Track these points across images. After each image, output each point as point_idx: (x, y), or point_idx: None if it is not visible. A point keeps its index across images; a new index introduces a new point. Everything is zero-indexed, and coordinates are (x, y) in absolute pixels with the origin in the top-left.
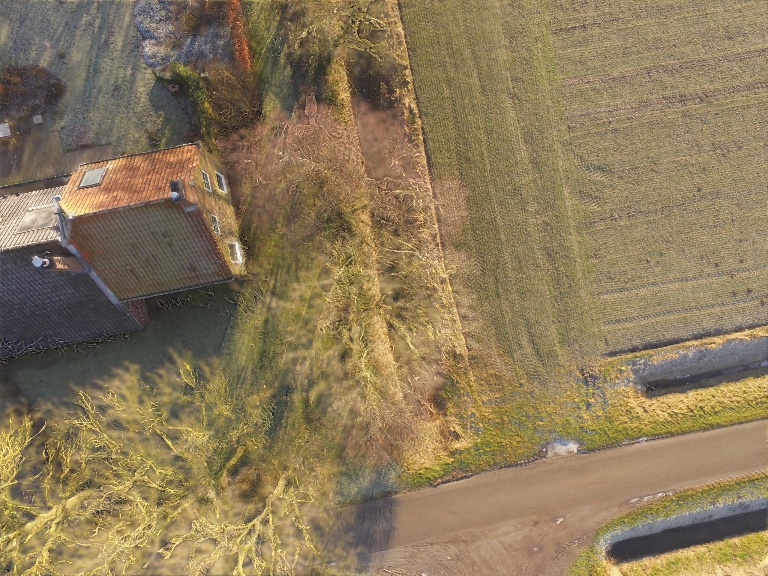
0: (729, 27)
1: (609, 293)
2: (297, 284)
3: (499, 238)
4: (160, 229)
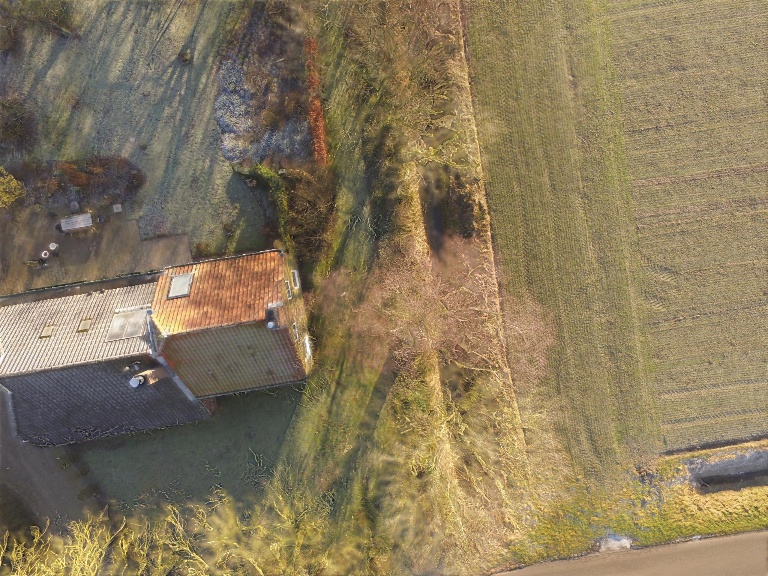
0: None
1: (670, 393)
2: (362, 374)
3: (563, 336)
4: (246, 343)
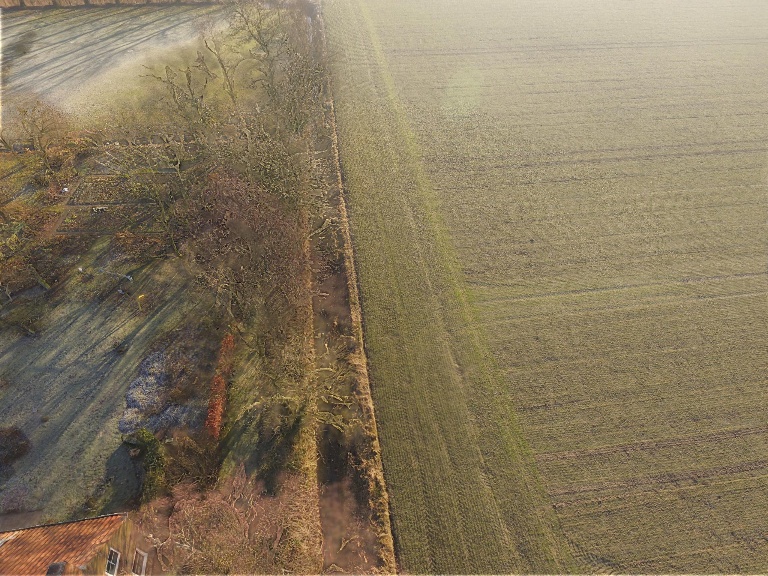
0: (690, 410)
1: None
2: None
3: None
4: None
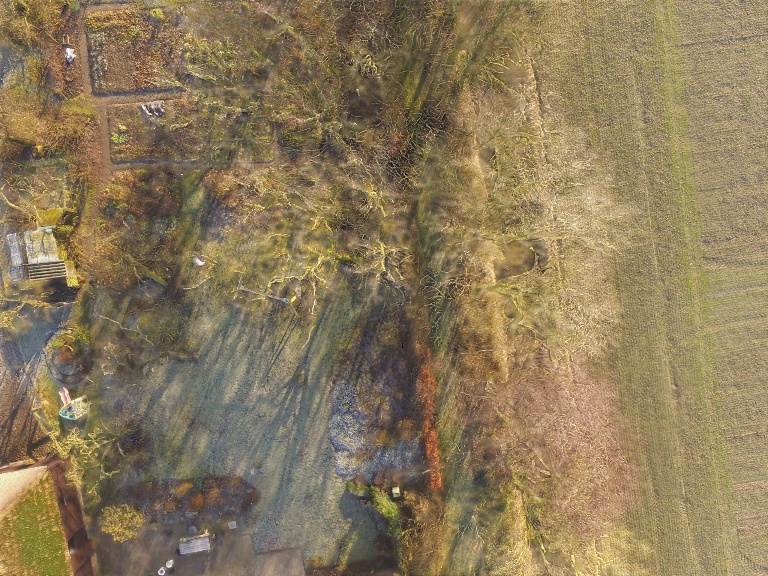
0: None
1: None
2: None
3: None
4: None
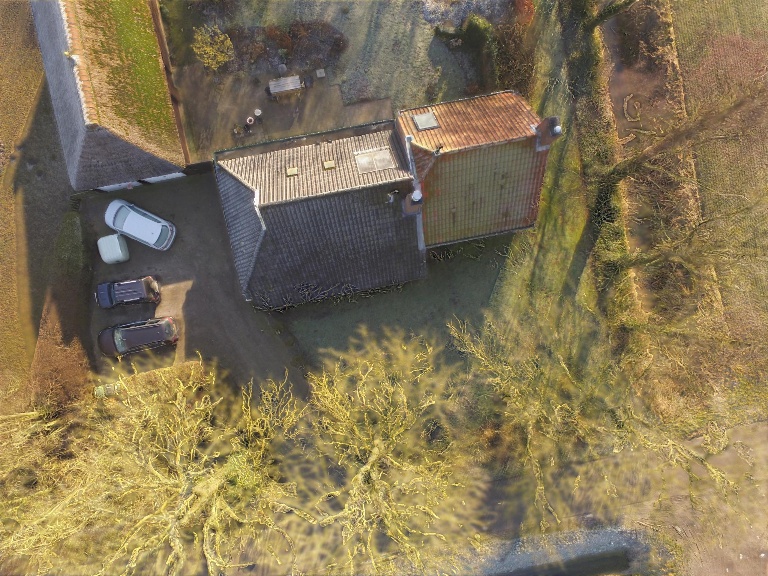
0: None
1: None
2: (563, 238)
3: None
4: (504, 169)
